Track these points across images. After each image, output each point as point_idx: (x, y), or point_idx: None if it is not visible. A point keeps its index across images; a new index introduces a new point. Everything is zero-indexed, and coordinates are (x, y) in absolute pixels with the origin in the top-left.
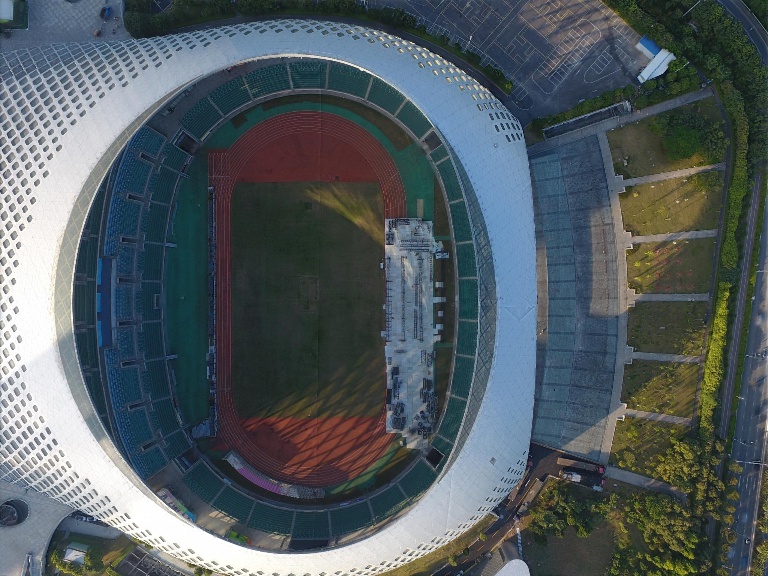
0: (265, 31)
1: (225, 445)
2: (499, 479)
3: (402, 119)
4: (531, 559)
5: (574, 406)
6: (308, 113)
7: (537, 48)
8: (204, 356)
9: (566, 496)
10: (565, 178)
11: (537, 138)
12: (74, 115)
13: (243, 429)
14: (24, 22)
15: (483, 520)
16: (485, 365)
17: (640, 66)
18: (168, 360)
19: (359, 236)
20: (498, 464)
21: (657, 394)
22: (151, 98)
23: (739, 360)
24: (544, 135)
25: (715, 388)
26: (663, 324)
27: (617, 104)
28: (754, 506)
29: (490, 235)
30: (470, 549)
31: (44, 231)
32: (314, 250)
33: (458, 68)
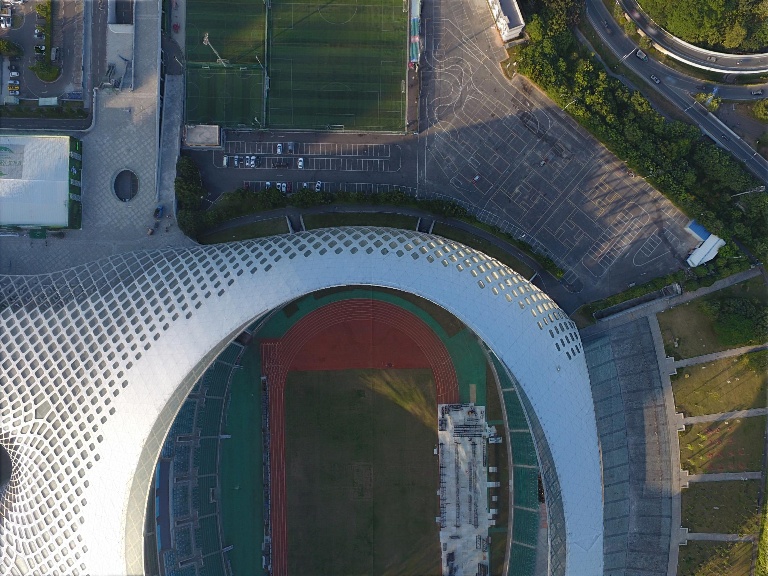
0: (325, 252)
1: None
2: None
3: None
4: None
5: None
6: (359, 301)
7: (586, 232)
8: (259, 546)
9: None
10: (616, 360)
11: (588, 322)
12: (139, 348)
13: None
14: (77, 222)
15: None
16: None
17: (689, 248)
18: (224, 552)
19: (412, 422)
20: None
21: (712, 574)
22: (217, 335)
23: None
24: None
25: None
26: (717, 504)
27: None
28: None
29: (558, 471)
30: None
31: (113, 472)
32: (368, 437)
33: (514, 275)
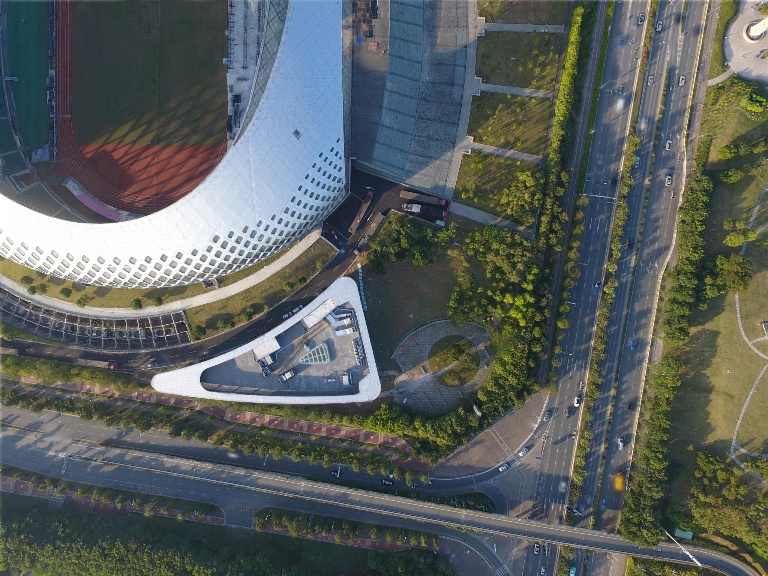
0: None
1: (65, 171)
2: (310, 164)
3: None
4: (372, 296)
5: (419, 139)
6: None
7: None
8: (44, 80)
9: (403, 223)
10: None
11: None
12: None
13: (83, 155)
14: None
15: (321, 250)
16: (278, 15)
17: None
18: (7, 81)
19: None
20: (304, 141)
21: (506, 129)
22: None
23: (593, 95)
24: None
25: (563, 117)
26: (514, 55)
27: None
28: (605, 249)
29: None
30: (310, 284)
31: None
32: None
33: None
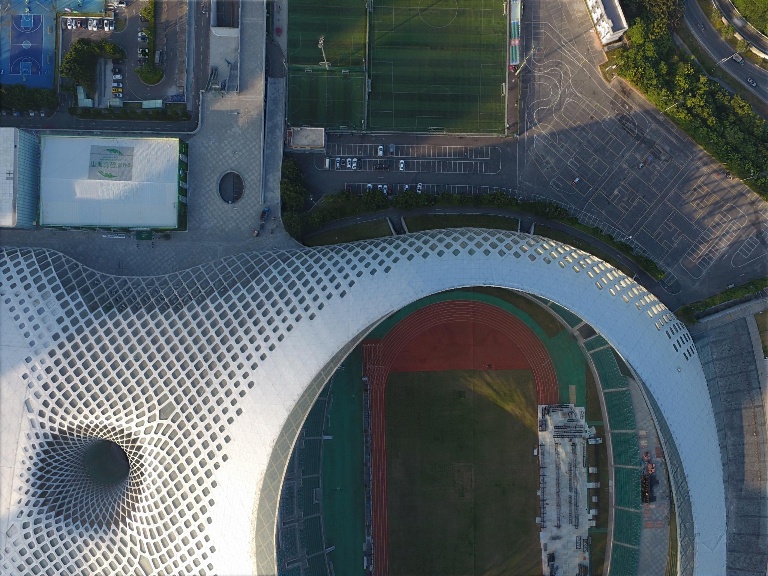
0: (443, 254)
1: None
2: None
3: (555, 309)
4: None
5: None
6: (460, 302)
7: (685, 234)
8: (361, 546)
9: None
10: (715, 361)
11: (687, 323)
12: (263, 349)
13: None
14: (184, 224)
15: None
16: None
17: None
18: (327, 553)
19: (512, 423)
20: None
21: None
22: (343, 336)
23: None
24: None
25: None
26: None
27: (765, 288)
28: None
29: (686, 471)
30: None
31: (242, 473)
32: (468, 438)
33: (625, 276)
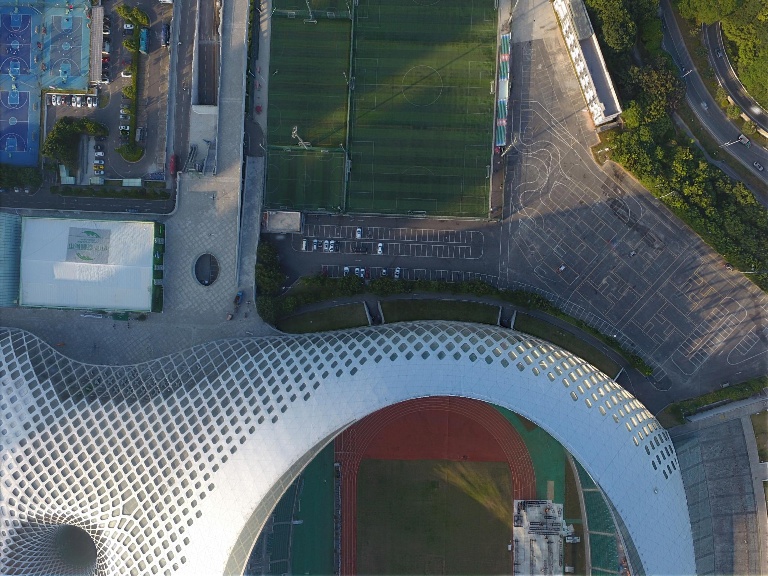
0: (412, 356)
1: None
2: None
3: None
4: None
5: None
6: None
7: (677, 327)
8: None
9: None
10: (705, 463)
11: (676, 421)
12: (225, 450)
13: None
14: (159, 305)
15: None
16: None
17: None
18: None
19: (487, 517)
20: None
21: None
22: (304, 444)
23: None
24: (684, 419)
25: None
26: None
27: (763, 388)
28: None
29: None
30: None
31: None
32: (440, 529)
33: (606, 381)
